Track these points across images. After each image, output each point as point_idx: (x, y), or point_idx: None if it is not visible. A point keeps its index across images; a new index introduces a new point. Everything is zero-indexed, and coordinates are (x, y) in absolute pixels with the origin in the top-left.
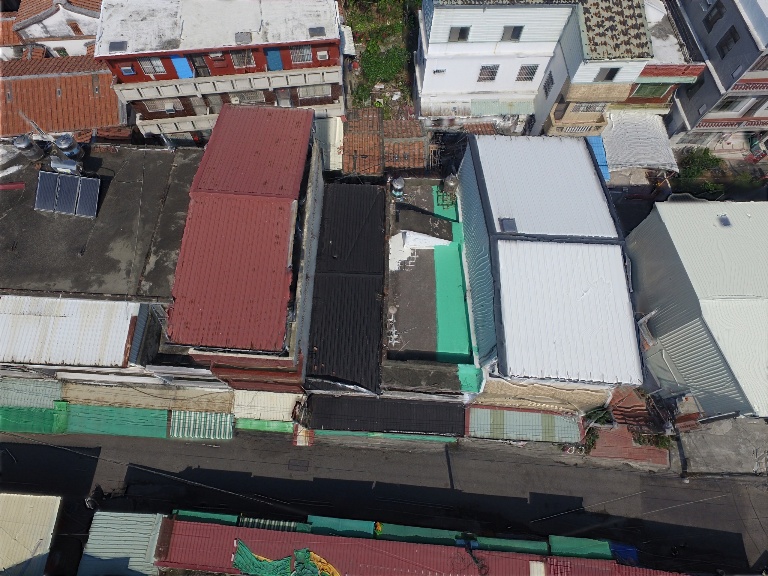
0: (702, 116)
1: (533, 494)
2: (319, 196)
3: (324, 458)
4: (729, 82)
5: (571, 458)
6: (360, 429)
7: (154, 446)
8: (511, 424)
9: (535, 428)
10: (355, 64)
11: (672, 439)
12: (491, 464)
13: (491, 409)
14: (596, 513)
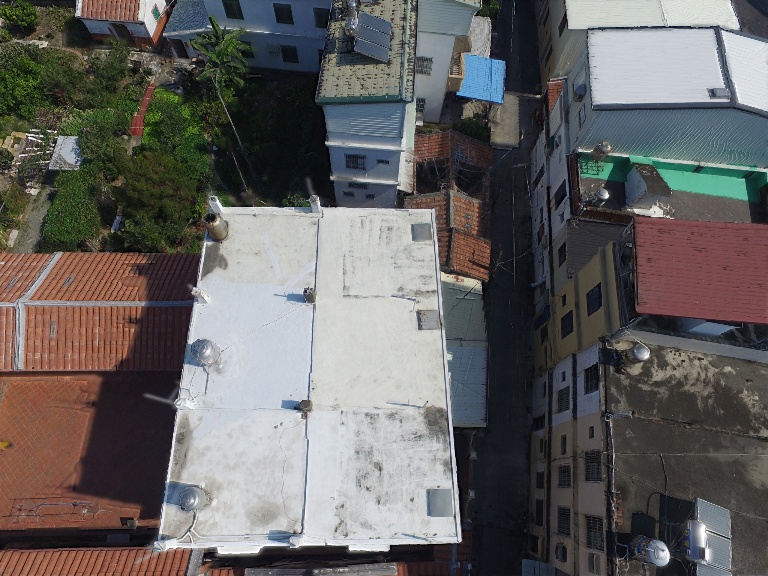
0: None
1: None
2: None
3: None
4: None
5: None
6: None
7: None
8: None
9: None
10: None
11: None
12: None
13: None
14: None
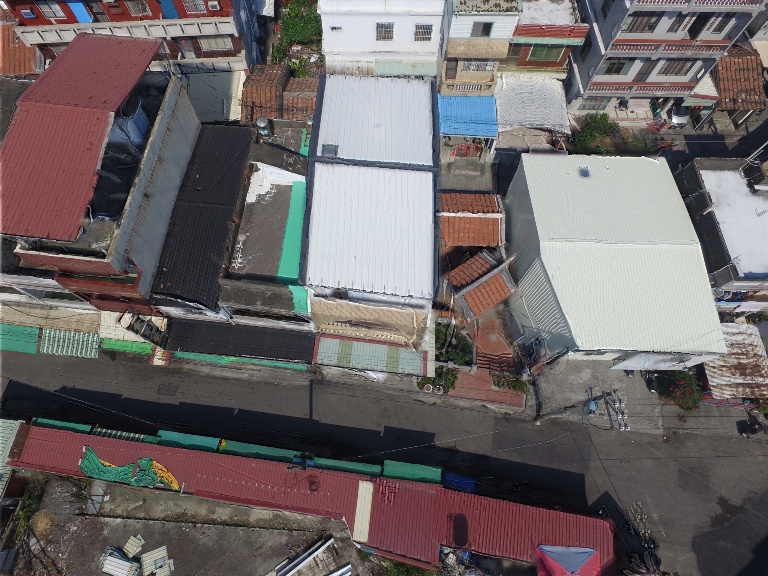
0: (591, 79)
1: (387, 428)
2: (187, 131)
3: (193, 385)
4: (608, 42)
5: (429, 397)
6: (214, 352)
7: (34, 366)
8: (358, 354)
9: (380, 359)
10: (278, 27)
11: (529, 383)
12: (352, 399)
13: (340, 339)
14: (446, 448)
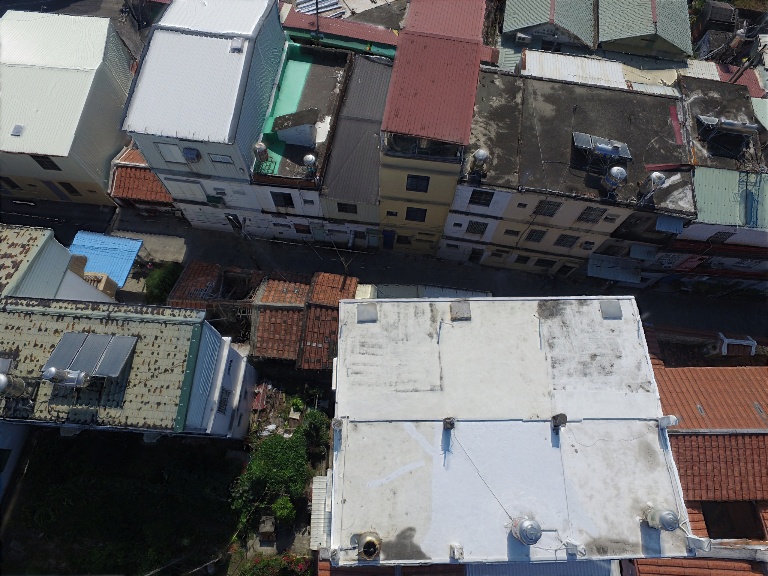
0: None
1: None
2: None
3: None
4: None
5: None
6: None
7: None
8: None
9: None
10: None
11: None
12: None
13: None
14: None
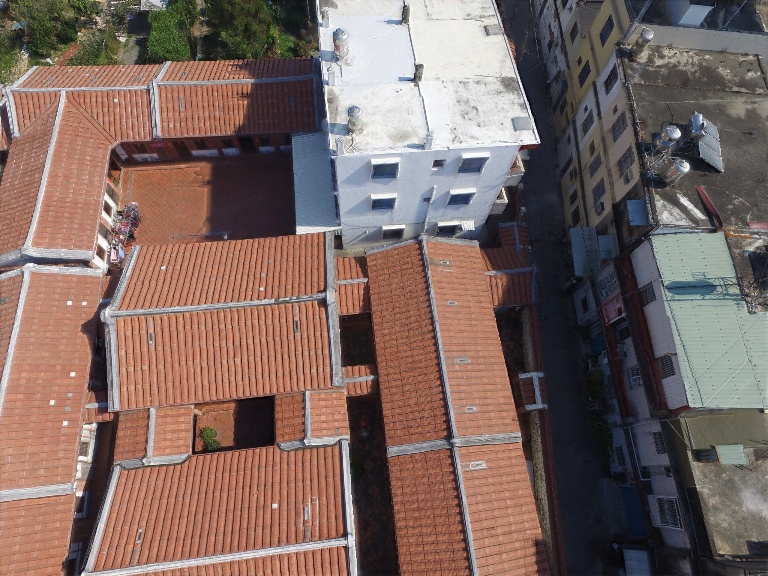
0: None
1: None
2: None
3: None
4: None
5: None
6: None
7: None
8: None
9: None
10: None
11: None
12: None
13: None
14: None
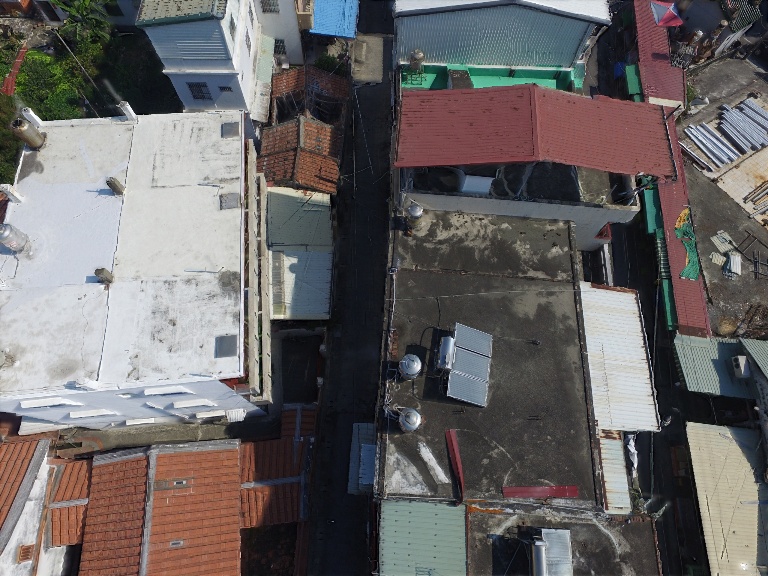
0: None
1: None
2: None
3: None
4: None
5: None
6: None
7: None
8: None
9: None
10: None
11: None
12: None
13: None
14: (598, 81)
